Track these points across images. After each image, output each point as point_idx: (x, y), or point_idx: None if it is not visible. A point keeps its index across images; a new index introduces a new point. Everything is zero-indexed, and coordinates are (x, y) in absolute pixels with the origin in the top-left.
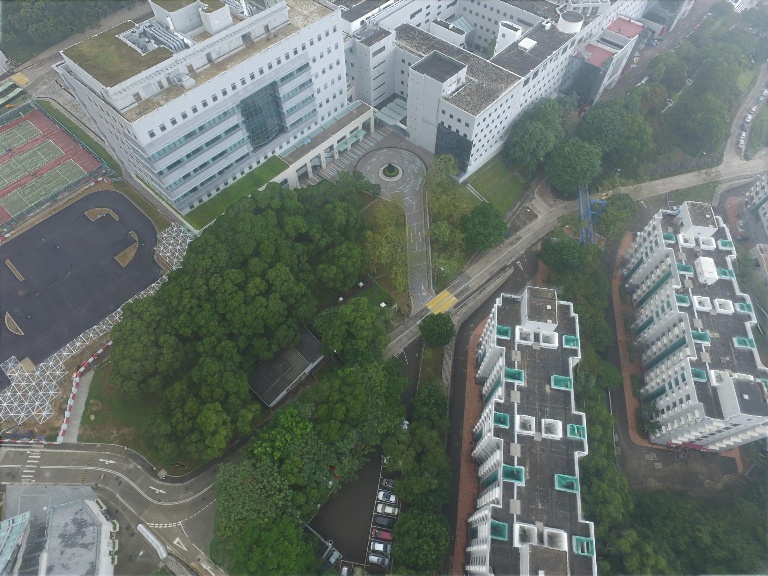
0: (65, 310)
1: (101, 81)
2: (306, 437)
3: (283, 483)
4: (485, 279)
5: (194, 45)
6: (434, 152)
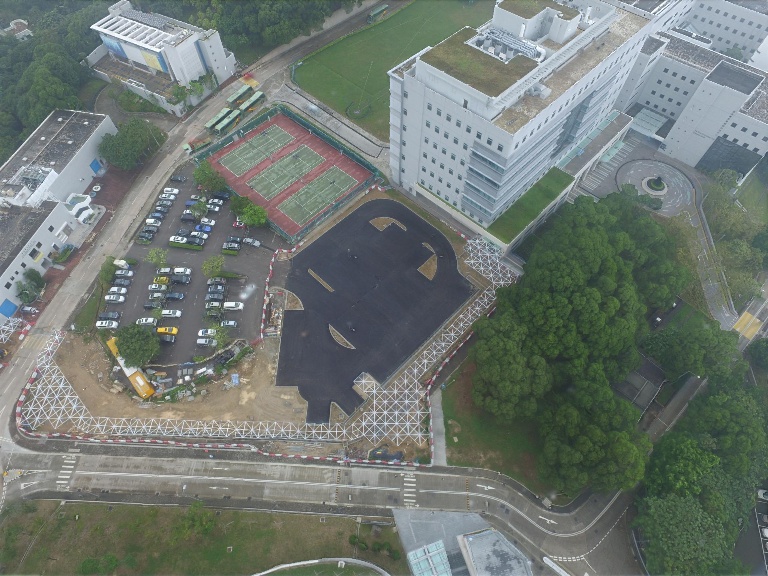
0: (388, 324)
1: (481, 90)
2: (713, 470)
3: (716, 521)
4: None
5: None
6: (695, 165)
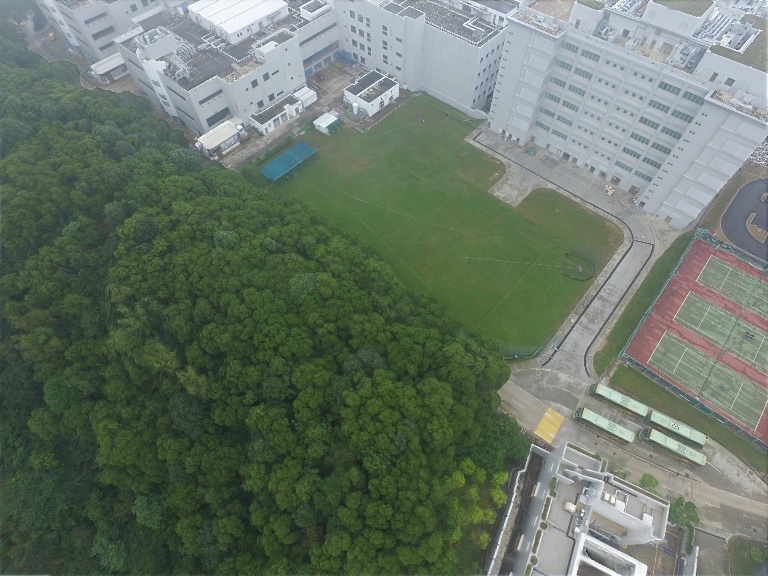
0: None
1: None
2: None
3: None
4: None
5: (724, 6)
6: None
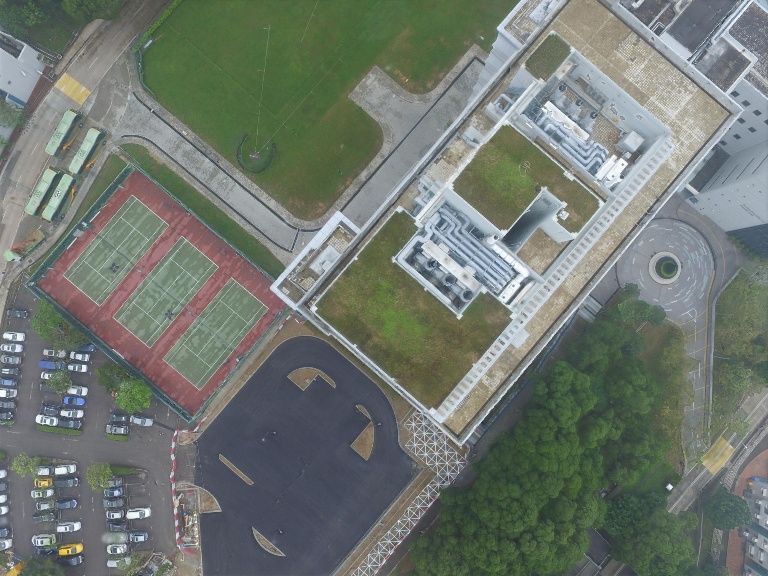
0: (318, 522)
1: (414, 393)
2: None
3: None
4: (763, 414)
5: None
6: (728, 231)
